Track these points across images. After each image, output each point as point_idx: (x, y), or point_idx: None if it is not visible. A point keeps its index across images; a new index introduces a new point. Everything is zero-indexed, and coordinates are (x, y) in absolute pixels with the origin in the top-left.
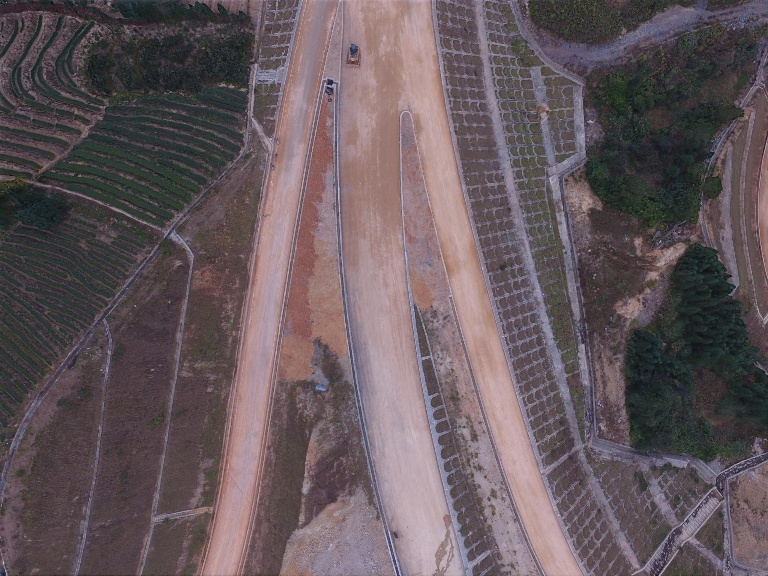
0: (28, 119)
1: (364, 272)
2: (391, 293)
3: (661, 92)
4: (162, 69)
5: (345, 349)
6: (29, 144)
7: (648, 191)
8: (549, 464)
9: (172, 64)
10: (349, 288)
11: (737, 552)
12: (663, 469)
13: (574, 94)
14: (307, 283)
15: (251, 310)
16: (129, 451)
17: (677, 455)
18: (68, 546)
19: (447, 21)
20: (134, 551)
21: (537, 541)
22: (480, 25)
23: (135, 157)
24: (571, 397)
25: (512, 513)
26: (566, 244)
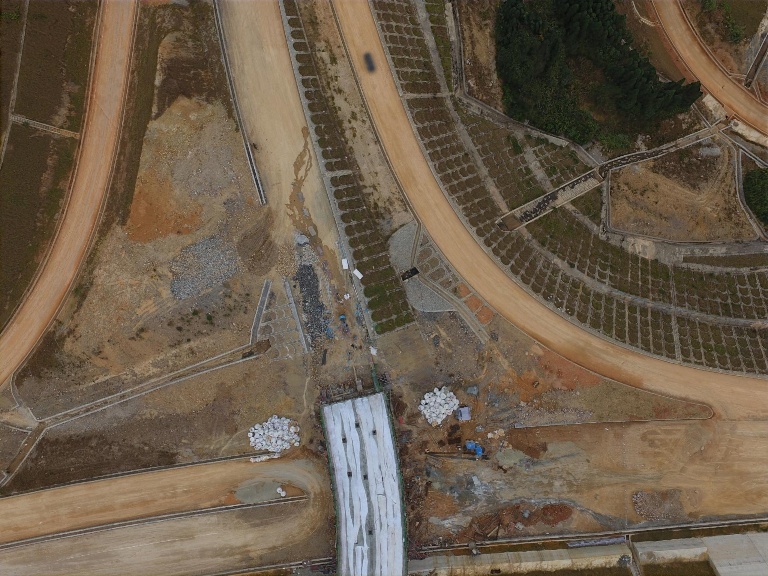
0: None
1: None
2: None
3: None
4: None
5: None
6: None
7: None
8: (409, 91)
9: None
10: None
11: (614, 220)
12: (538, 139)
13: None
14: None
15: None
16: None
17: None
18: None
19: None
20: None
21: (399, 165)
22: None
23: None
24: (436, 45)
25: (373, 136)
26: None
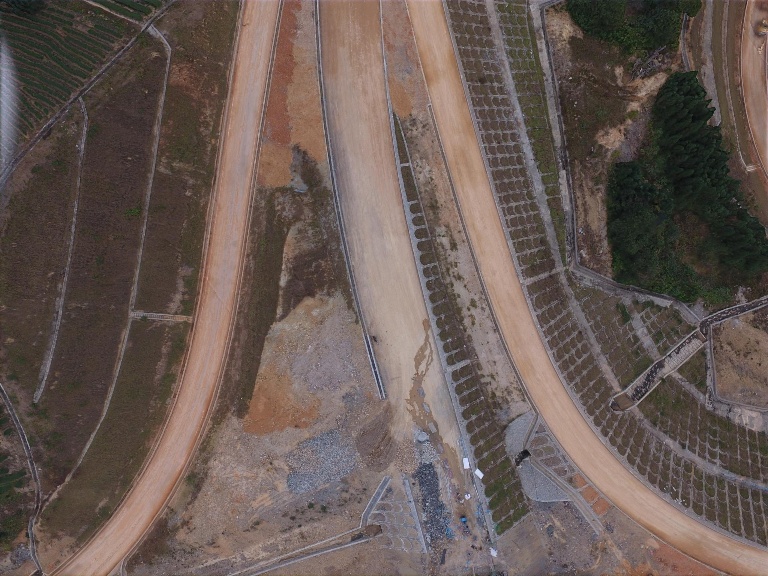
0: None
1: (343, 80)
2: (370, 101)
3: None
4: None
5: (324, 155)
6: None
7: (629, 19)
8: (529, 276)
9: None
10: (328, 96)
11: (720, 388)
12: (645, 304)
13: None
14: (286, 90)
15: (230, 119)
16: (106, 236)
17: (660, 297)
18: (44, 322)
19: None
20: (112, 345)
21: (517, 352)
22: None
23: None
24: (552, 219)
25: (492, 323)
26: (547, 71)
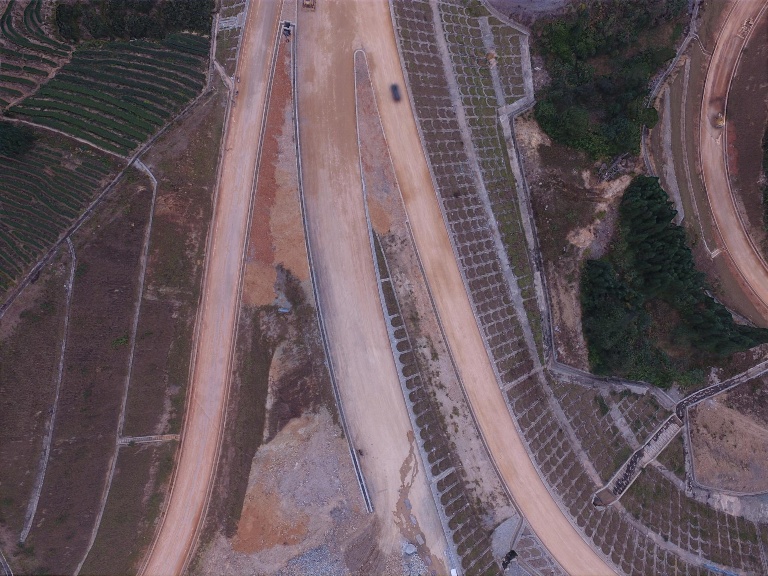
0: None
1: (324, 200)
2: (350, 219)
3: (601, 39)
4: (127, 17)
5: (307, 273)
6: None
7: (592, 127)
8: (508, 382)
9: (137, 13)
10: (309, 216)
11: (698, 473)
12: (623, 394)
13: (521, 43)
14: (269, 212)
15: (215, 240)
16: (93, 369)
17: (637, 384)
18: (31, 461)
19: None
20: (99, 473)
21: (500, 457)
22: None
23: (100, 94)
24: (528, 321)
25: (474, 430)
26: (518, 178)
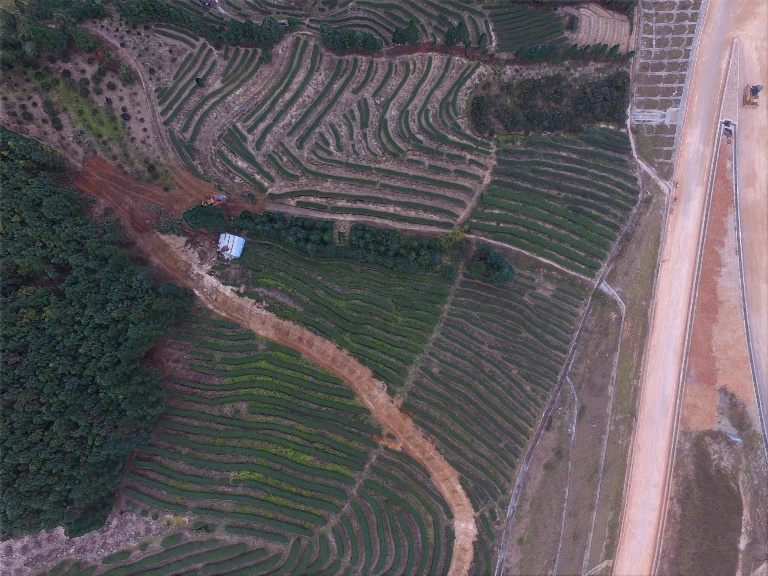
0: (422, 164)
1: (767, 318)
2: None
3: None
4: (546, 110)
5: (752, 397)
6: (436, 191)
7: None
8: None
9: None
10: (752, 334)
11: None
12: None
13: None
14: (711, 330)
15: (649, 358)
16: (578, 510)
17: None
18: None
19: None
20: None
21: None
22: None
23: (547, 204)
24: None
25: None
26: None
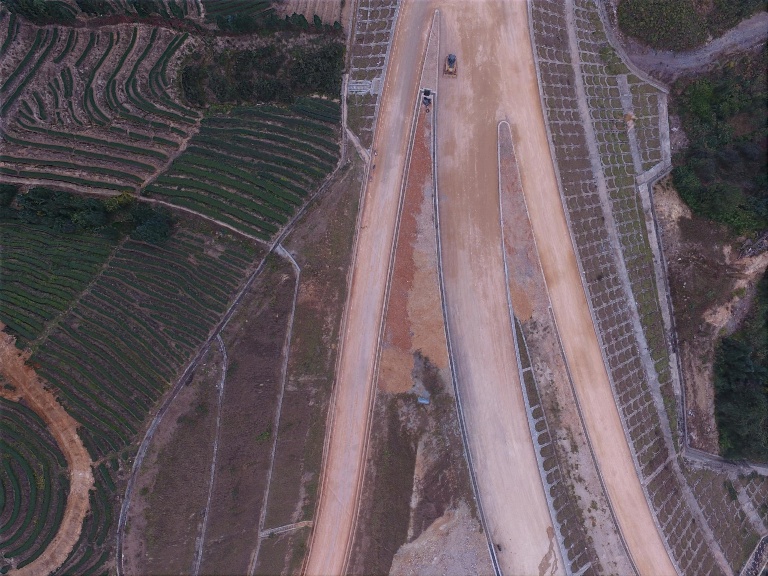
0: (124, 132)
1: (463, 284)
2: (491, 304)
3: (747, 99)
4: (256, 80)
5: (446, 361)
6: (129, 158)
7: None
8: (648, 475)
9: (264, 75)
10: (448, 300)
11: None
12: (750, 477)
13: (659, 101)
14: (407, 295)
15: (349, 322)
16: (240, 467)
17: (761, 463)
18: (184, 563)
19: (542, 30)
20: (242, 566)
21: (637, 552)
22: (571, 33)
23: (236, 170)
24: (665, 407)
25: (612, 524)
26: (656, 253)
